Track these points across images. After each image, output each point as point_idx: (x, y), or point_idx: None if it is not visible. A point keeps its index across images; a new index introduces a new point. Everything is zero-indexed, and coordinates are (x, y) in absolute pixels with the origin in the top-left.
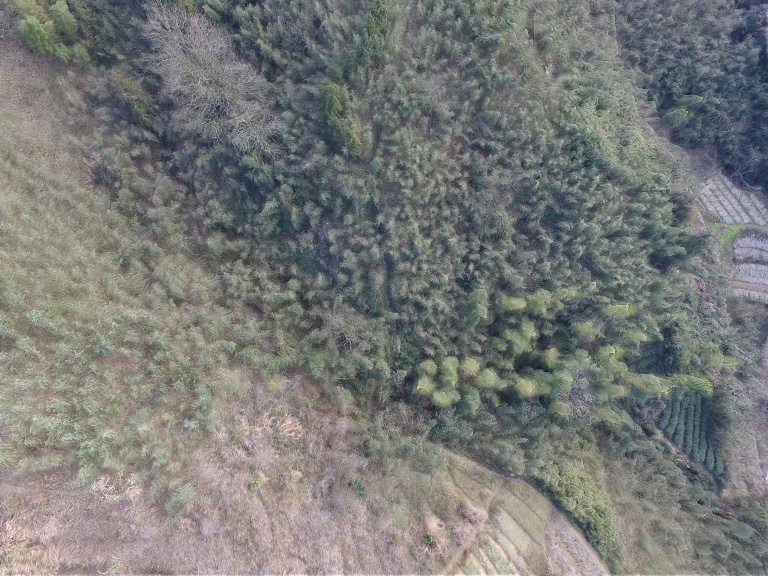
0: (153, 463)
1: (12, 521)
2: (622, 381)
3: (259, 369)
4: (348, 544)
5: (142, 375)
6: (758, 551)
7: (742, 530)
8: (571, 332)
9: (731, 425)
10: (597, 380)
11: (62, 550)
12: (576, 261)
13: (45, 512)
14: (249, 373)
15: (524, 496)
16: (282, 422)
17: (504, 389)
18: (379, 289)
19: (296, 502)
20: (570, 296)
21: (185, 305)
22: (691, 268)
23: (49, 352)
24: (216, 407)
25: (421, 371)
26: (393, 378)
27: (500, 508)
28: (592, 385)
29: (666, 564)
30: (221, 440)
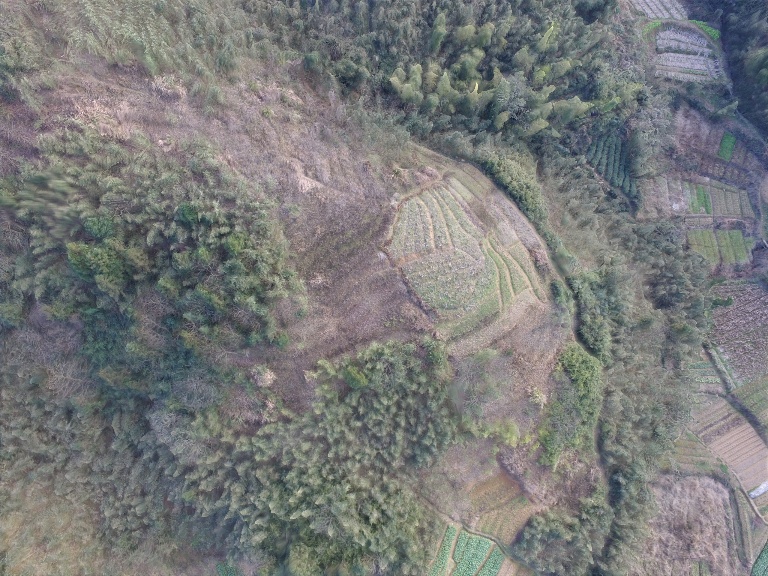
0: (196, 66)
1: (97, 101)
2: (557, 121)
3: (270, 64)
4: (334, 161)
5: (187, 24)
6: (659, 244)
7: (647, 227)
8: (513, 64)
9: (641, 151)
10: (532, 99)
11: (132, 126)
12: (517, 9)
13: (120, 99)
14: (262, 63)
15: (471, 172)
16: (287, 90)
17: (459, 105)
18: (362, 17)
19: (297, 131)
20: (512, 34)
21: (215, 3)
22: (611, 25)
23: (121, 2)
24: (238, 70)
25: (393, 76)
26: (372, 80)
27: (452, 176)
28: (528, 105)
29: (581, 231)
30: (242, 87)
